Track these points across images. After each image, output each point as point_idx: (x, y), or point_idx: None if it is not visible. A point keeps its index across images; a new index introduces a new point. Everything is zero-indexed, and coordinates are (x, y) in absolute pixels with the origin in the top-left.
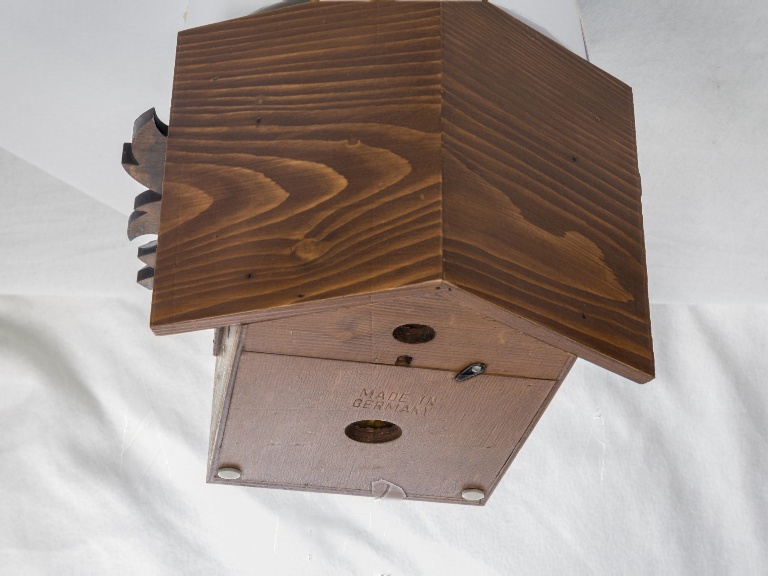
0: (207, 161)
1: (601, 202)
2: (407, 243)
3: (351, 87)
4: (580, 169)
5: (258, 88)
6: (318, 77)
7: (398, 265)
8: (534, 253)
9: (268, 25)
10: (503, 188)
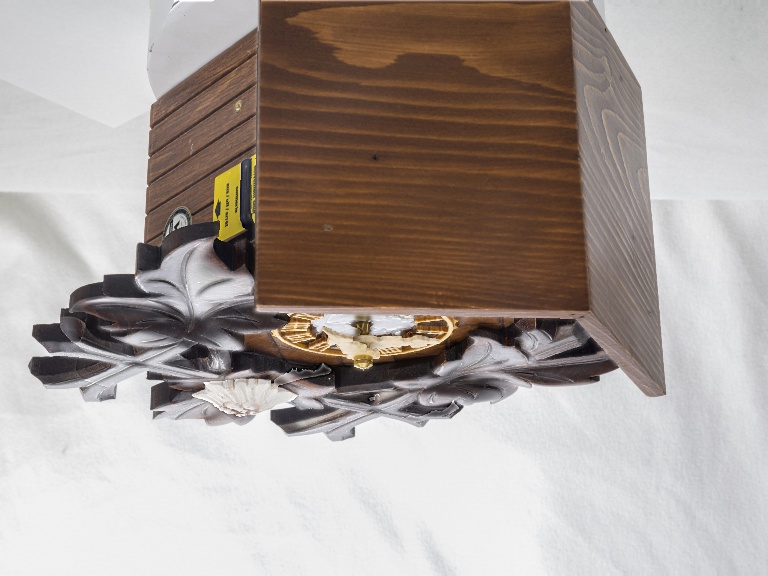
0: None
1: (333, 119)
2: None
3: None
4: (366, 148)
5: None
6: None
7: None
8: (444, 23)
9: None
10: (489, 80)
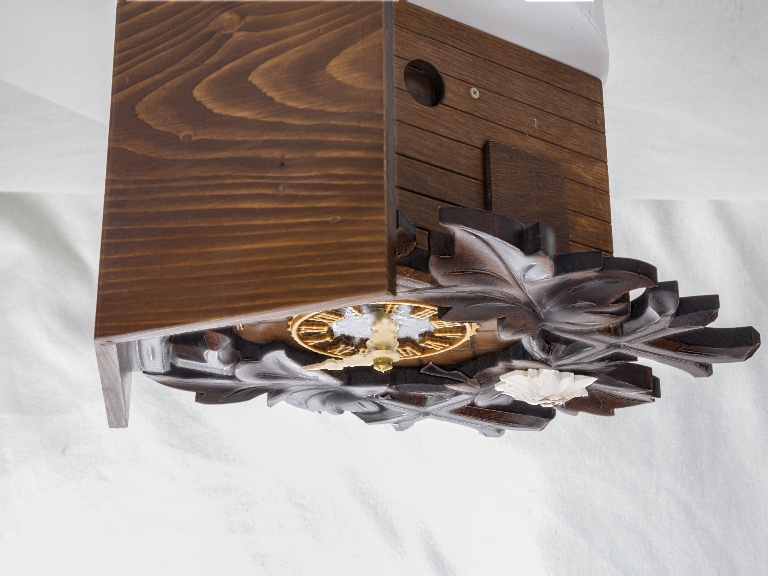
0: (336, 115)
1: None
2: (142, 34)
3: (187, 201)
4: None
5: (284, 204)
6: (220, 215)
7: (151, 12)
8: None
9: (276, 289)
10: None
